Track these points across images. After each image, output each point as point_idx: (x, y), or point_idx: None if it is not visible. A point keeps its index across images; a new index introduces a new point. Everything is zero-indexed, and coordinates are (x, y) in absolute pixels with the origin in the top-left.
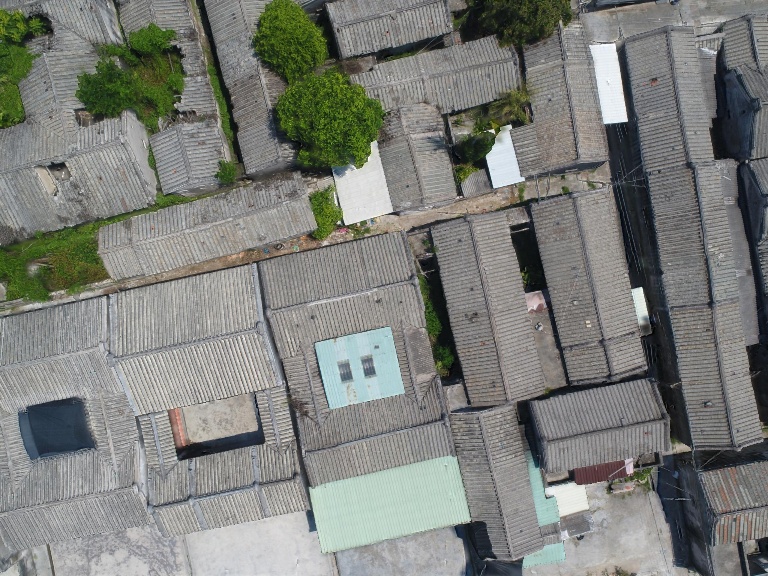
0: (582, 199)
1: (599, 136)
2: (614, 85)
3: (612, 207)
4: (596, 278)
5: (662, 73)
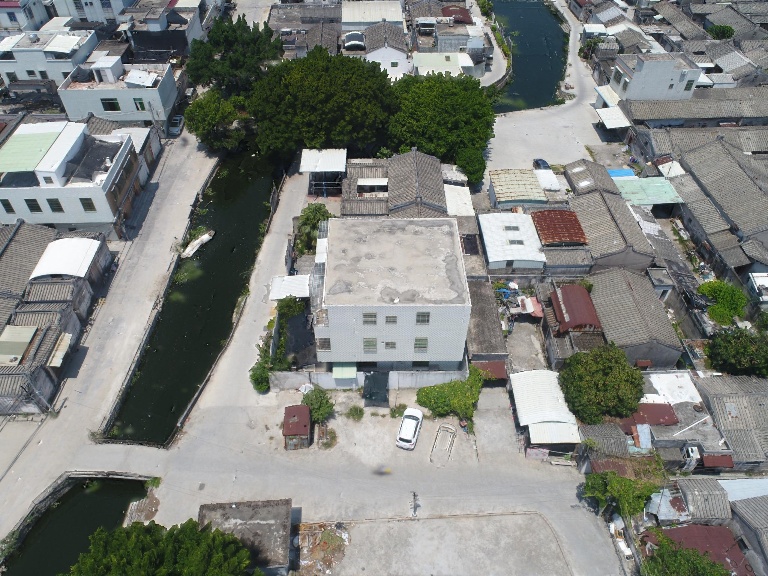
0: None
1: None
2: None
3: (757, 0)
4: None
5: None
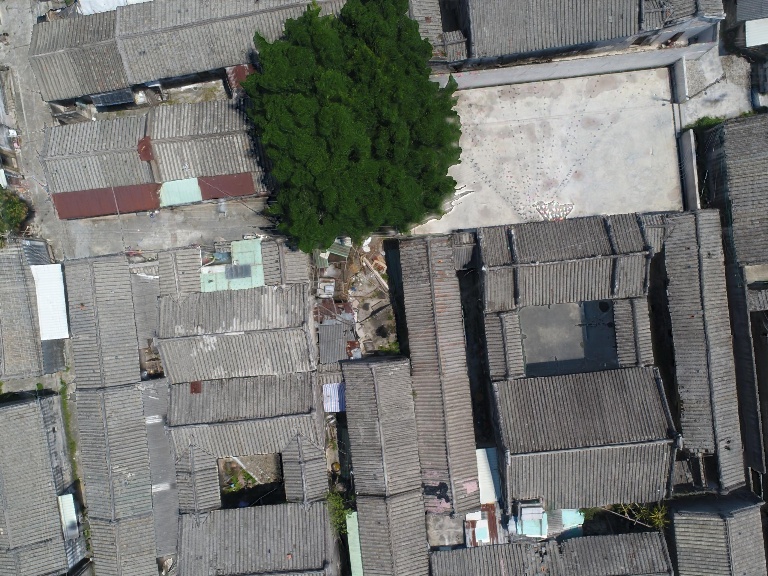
0: (0, 415)
1: (33, 353)
2: (56, 303)
3: (42, 419)
4: (9, 490)
5: (87, 300)
